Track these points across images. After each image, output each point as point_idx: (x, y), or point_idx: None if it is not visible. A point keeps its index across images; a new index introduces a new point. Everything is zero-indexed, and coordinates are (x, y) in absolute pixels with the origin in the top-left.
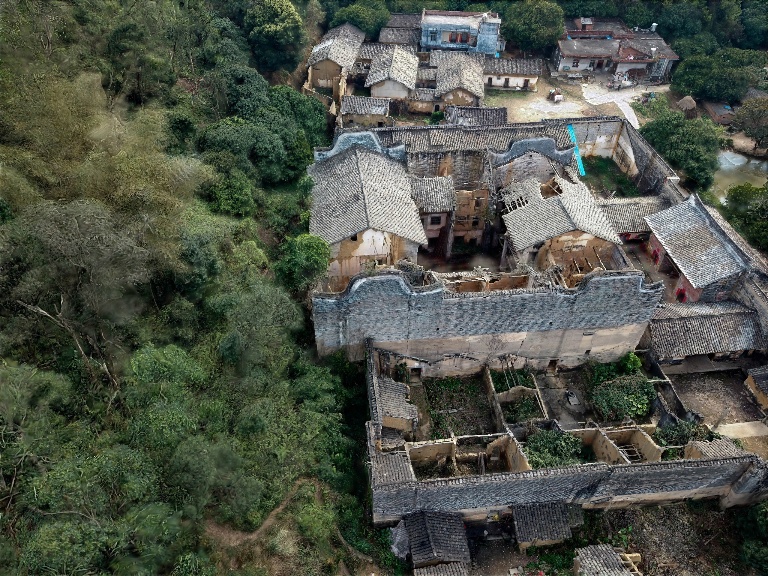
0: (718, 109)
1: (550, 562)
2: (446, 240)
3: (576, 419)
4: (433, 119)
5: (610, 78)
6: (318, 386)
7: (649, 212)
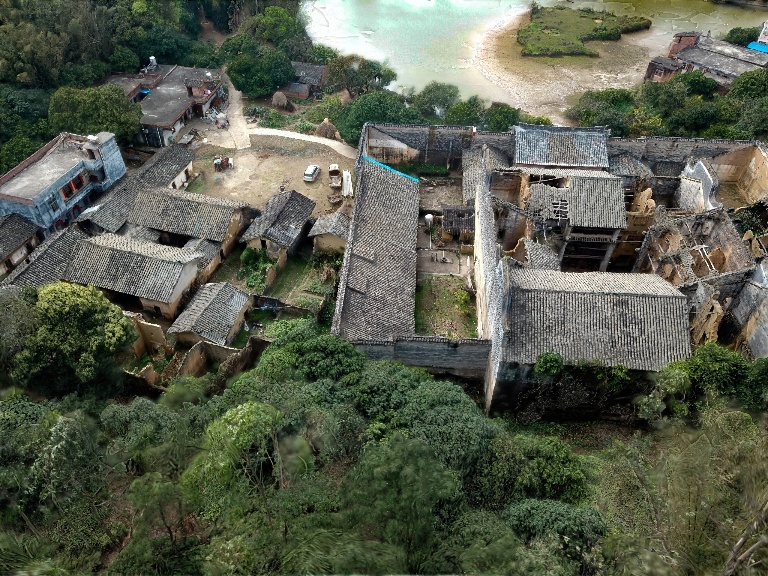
0: (296, 89)
1: None
2: None
3: None
4: (250, 262)
5: (207, 121)
6: None
7: (497, 160)
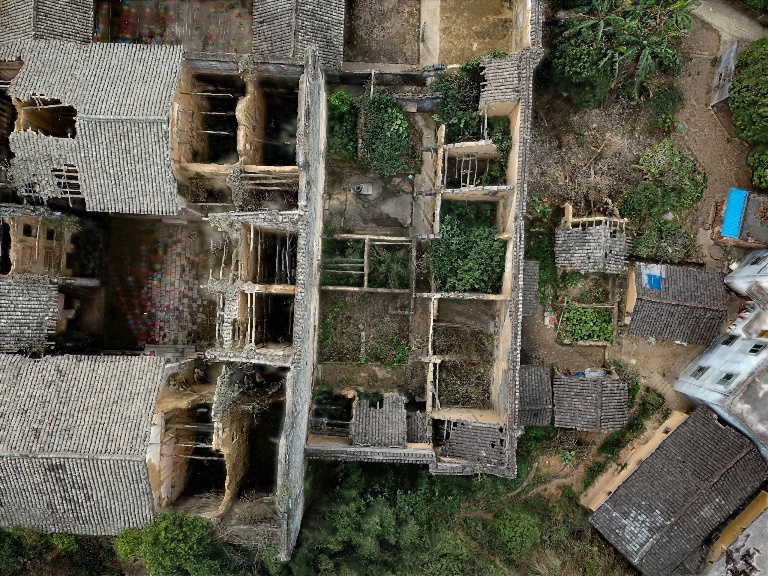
0: None
1: (544, 284)
2: (78, 286)
3: (391, 196)
4: None
5: None
6: (379, 529)
7: None
